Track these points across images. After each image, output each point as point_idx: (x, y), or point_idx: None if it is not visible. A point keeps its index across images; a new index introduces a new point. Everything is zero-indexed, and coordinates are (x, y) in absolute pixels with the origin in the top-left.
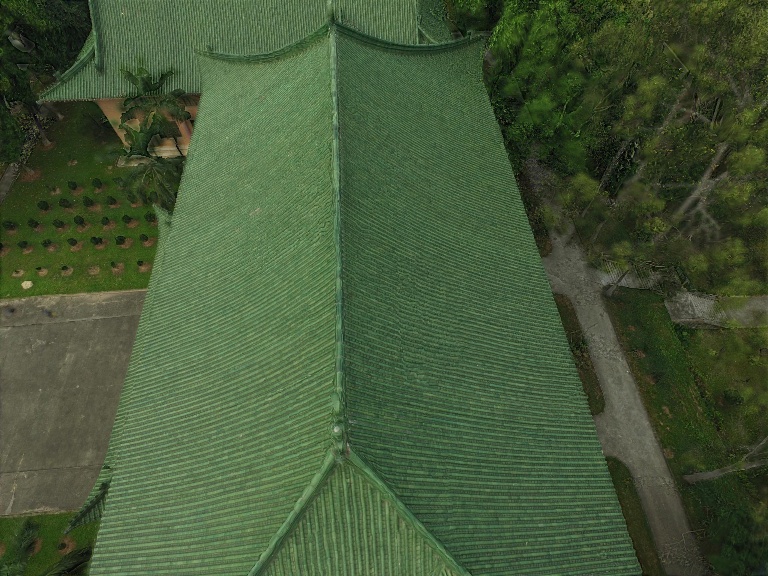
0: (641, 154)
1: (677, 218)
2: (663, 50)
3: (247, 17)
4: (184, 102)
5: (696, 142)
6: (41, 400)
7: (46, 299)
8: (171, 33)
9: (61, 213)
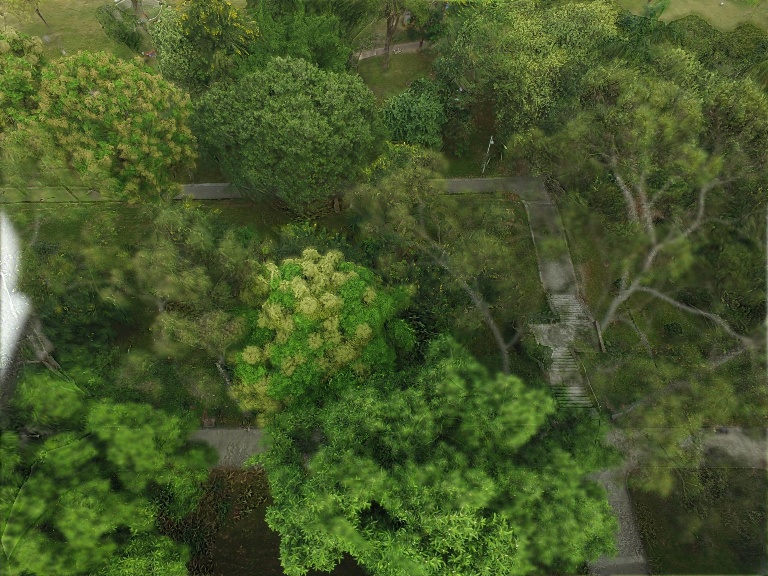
0: (434, 318)
1: (497, 306)
2: (279, 234)
3: None
4: None
5: (434, 257)
6: None
7: None
8: None
9: None
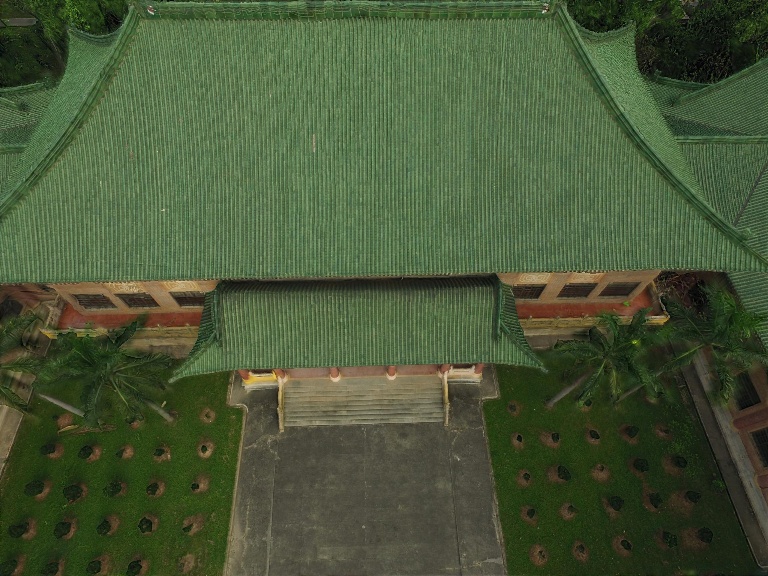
0: None
1: None
2: None
3: None
4: None
5: None
6: (378, 572)
7: None
8: None
9: None
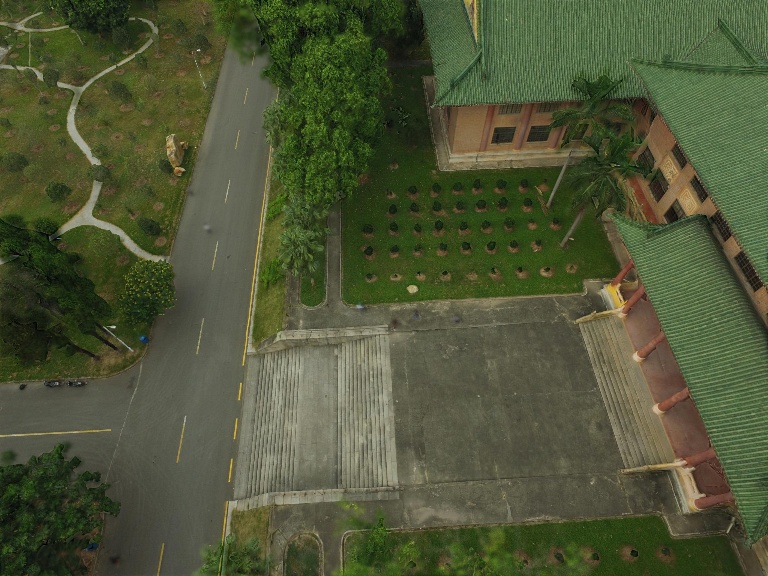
0: None
1: None
2: None
3: (628, 25)
4: (539, 108)
5: None
6: (485, 406)
7: (437, 304)
8: (552, 40)
9: (408, 217)
